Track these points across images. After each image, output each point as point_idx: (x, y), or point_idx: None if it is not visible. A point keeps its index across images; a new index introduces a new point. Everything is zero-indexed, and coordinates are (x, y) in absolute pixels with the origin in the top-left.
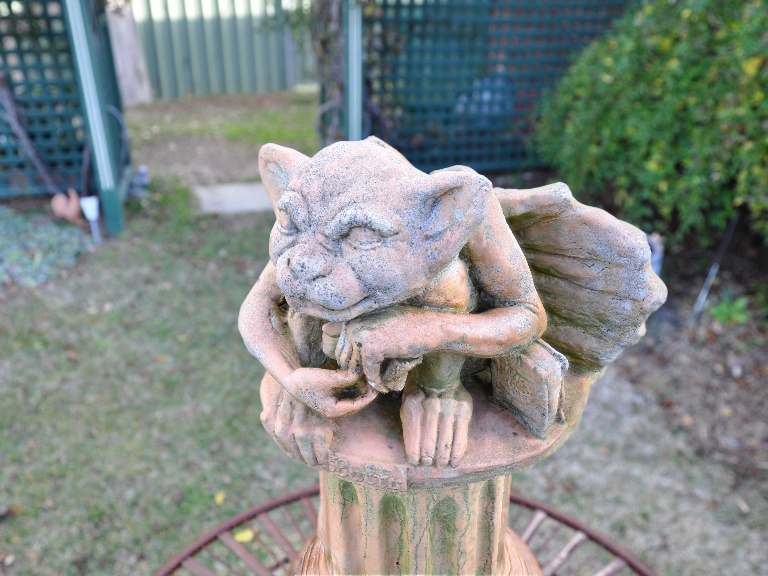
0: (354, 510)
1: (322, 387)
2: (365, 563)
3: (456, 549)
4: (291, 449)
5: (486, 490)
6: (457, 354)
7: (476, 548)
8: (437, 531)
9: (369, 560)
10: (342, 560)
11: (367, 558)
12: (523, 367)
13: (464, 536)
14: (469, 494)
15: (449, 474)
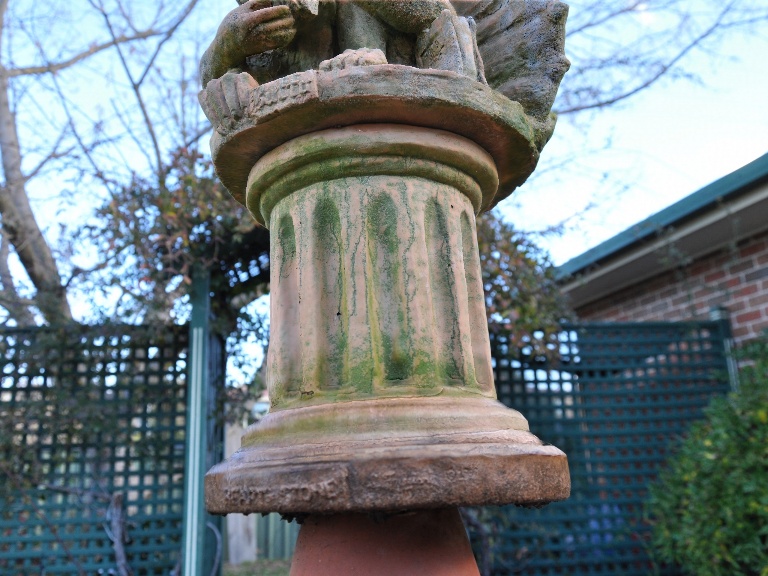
0: (294, 267)
1: (243, 7)
2: (300, 312)
3: (401, 269)
4: (218, 100)
5: (437, 225)
6: (367, 7)
7: (437, 312)
8: (380, 257)
9: (303, 302)
10: (279, 338)
11: (301, 301)
12: (432, 26)
13: (409, 251)
14: (408, 196)
15: (357, 70)
